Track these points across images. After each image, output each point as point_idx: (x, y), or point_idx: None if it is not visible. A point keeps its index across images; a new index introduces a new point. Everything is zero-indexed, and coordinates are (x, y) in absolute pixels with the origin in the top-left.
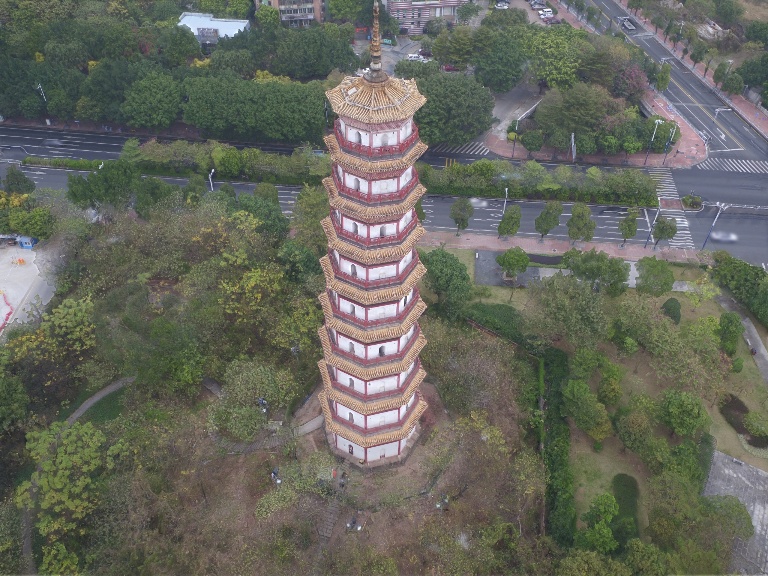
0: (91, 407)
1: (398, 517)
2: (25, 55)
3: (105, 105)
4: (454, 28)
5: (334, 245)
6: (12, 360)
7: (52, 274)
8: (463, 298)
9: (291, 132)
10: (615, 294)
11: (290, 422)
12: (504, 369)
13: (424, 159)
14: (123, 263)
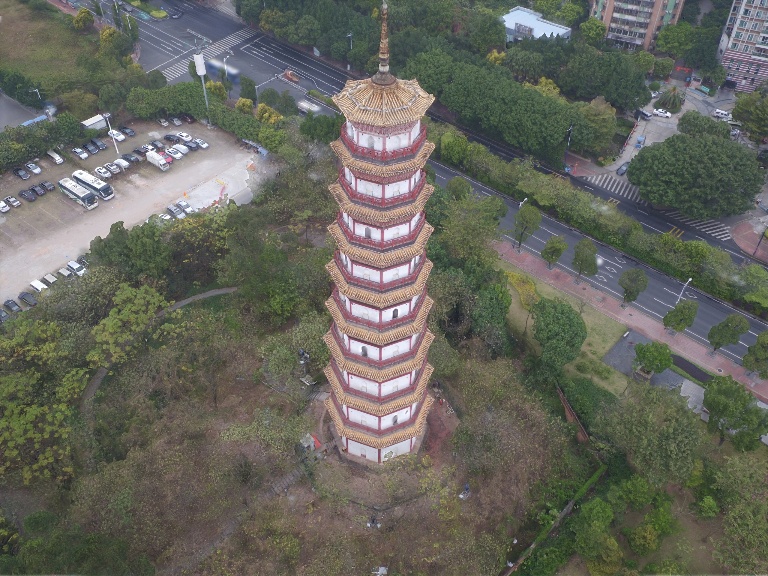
0: (213, 296)
1: (341, 514)
2: (367, 8)
3: (390, 66)
4: (767, 94)
5: (332, 228)
6: (168, 231)
7: (255, 184)
8: (557, 362)
9: (526, 142)
10: (738, 446)
11: (322, 385)
12: (540, 449)
13: (649, 218)
14: (304, 197)
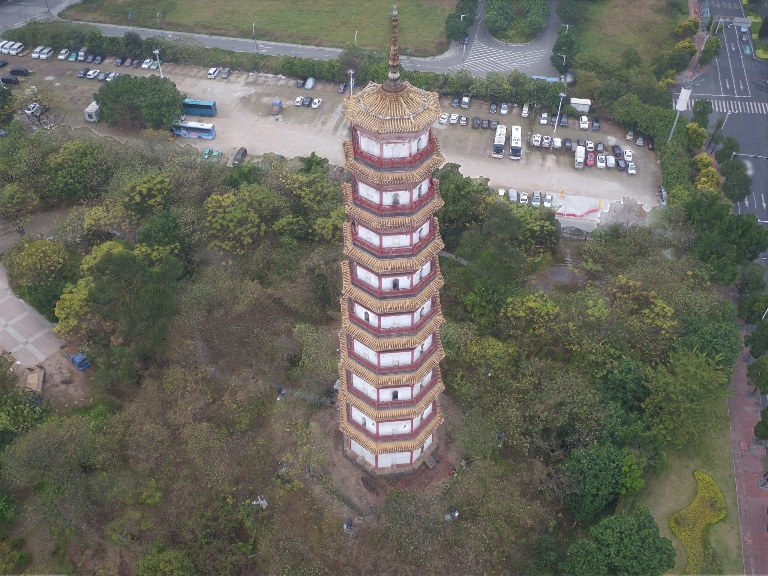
0: None
1: None
2: None
3: None
4: None
5: None
6: None
7: (605, 220)
8: (580, 567)
9: None
10: None
11: None
12: None
13: None
14: None
